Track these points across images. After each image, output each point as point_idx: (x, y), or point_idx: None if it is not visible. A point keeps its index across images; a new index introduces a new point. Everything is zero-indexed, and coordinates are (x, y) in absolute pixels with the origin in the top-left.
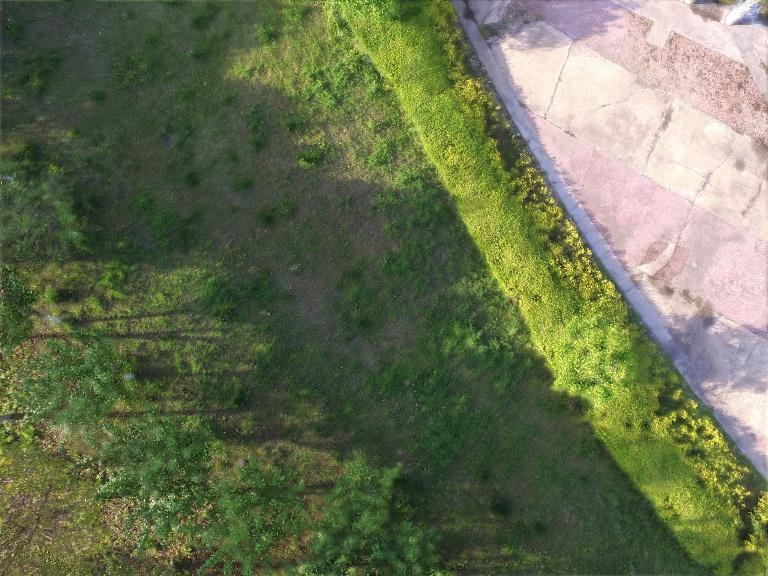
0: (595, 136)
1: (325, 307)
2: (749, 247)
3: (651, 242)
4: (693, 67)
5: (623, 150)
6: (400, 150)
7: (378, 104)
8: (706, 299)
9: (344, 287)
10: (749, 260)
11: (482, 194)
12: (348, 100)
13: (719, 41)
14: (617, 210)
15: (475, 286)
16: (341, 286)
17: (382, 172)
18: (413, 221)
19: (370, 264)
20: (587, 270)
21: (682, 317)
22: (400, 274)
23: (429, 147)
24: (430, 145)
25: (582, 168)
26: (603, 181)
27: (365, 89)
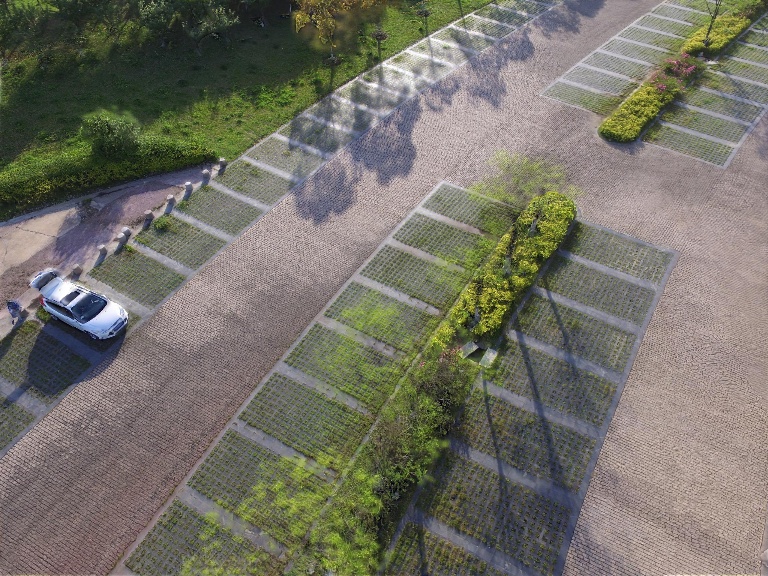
0: None
1: None
2: None
3: None
4: (3, 295)
5: None
6: None
7: None
8: None
9: None
10: None
11: None
12: None
13: None
14: None
15: None
16: None
17: None
18: None
19: None
20: None
21: None
22: None
23: None
24: None
25: None
26: None
27: None
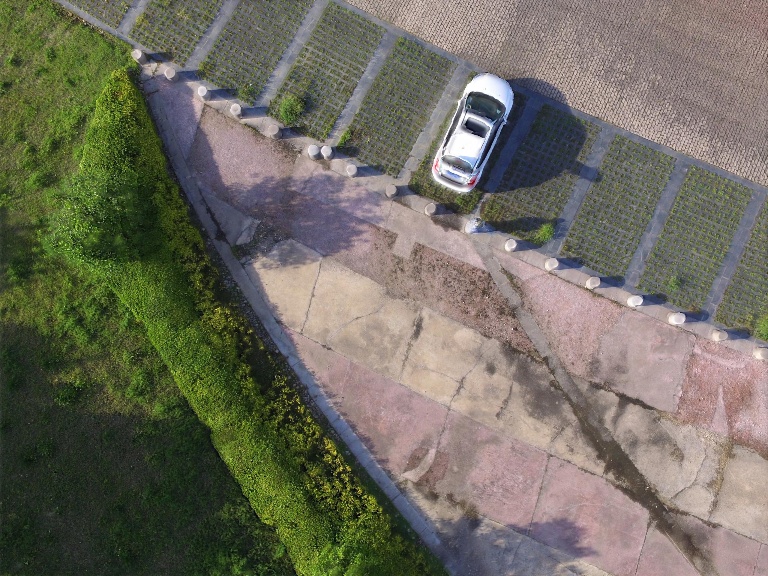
0: (351, 348)
1: (86, 549)
2: (506, 447)
3: (412, 449)
4: (438, 276)
5: (379, 360)
6: (157, 380)
7: (133, 335)
8: (469, 502)
9: (104, 526)
10: (507, 460)
11: (232, 426)
12: (102, 334)
13: (461, 249)
14: (377, 420)
15: (237, 513)
16: (101, 526)
17: (140, 404)
18: (171, 453)
19: (130, 500)
20: (346, 488)
21: (447, 521)
22: (161, 508)
23: (178, 382)
24: (179, 380)
25: (341, 380)
26: (362, 392)
27: (119, 321)
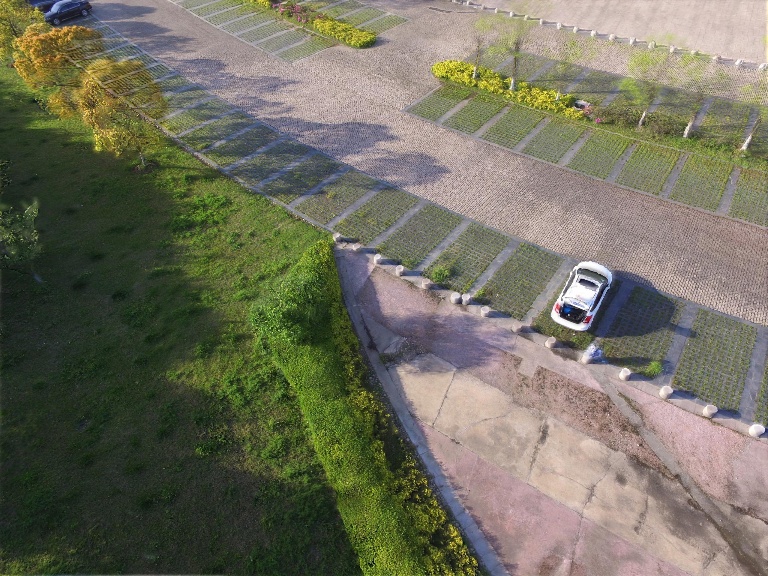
0: (479, 445)
1: None
2: (652, 569)
3: (544, 556)
4: (561, 393)
5: (506, 459)
6: (294, 446)
7: (282, 407)
8: None
9: None
10: None
11: (362, 492)
12: (256, 402)
13: (579, 375)
14: (505, 518)
15: None
16: None
17: (272, 465)
18: (291, 516)
19: (235, 562)
20: None
21: None
22: None
23: (318, 444)
24: (319, 443)
25: (468, 474)
26: (489, 487)
27: (274, 394)
